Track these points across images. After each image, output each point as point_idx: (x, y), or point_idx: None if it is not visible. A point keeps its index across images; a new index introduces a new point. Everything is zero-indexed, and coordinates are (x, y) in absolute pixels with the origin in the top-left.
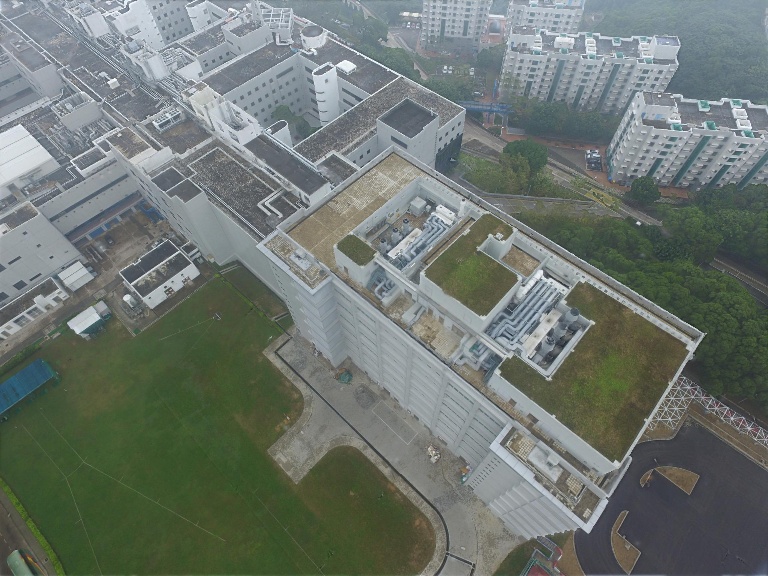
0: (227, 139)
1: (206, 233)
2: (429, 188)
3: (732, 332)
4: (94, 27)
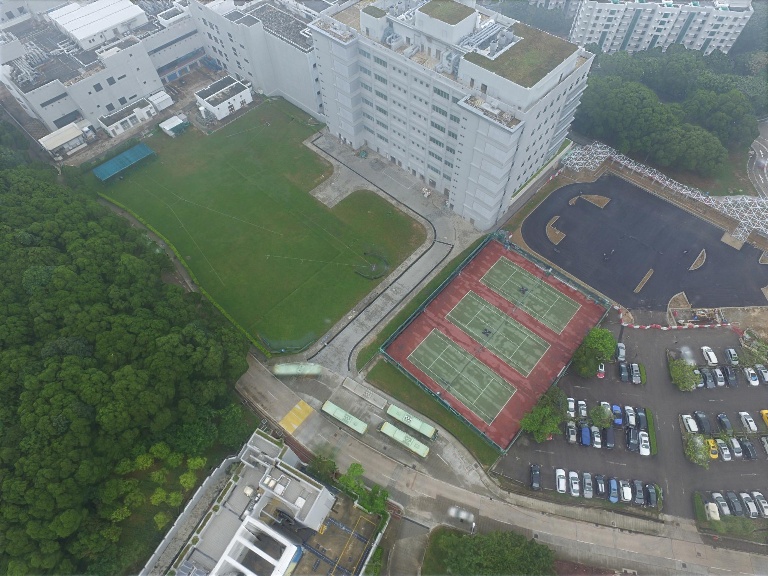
0: None
1: (260, 61)
2: None
3: (635, 104)
4: None
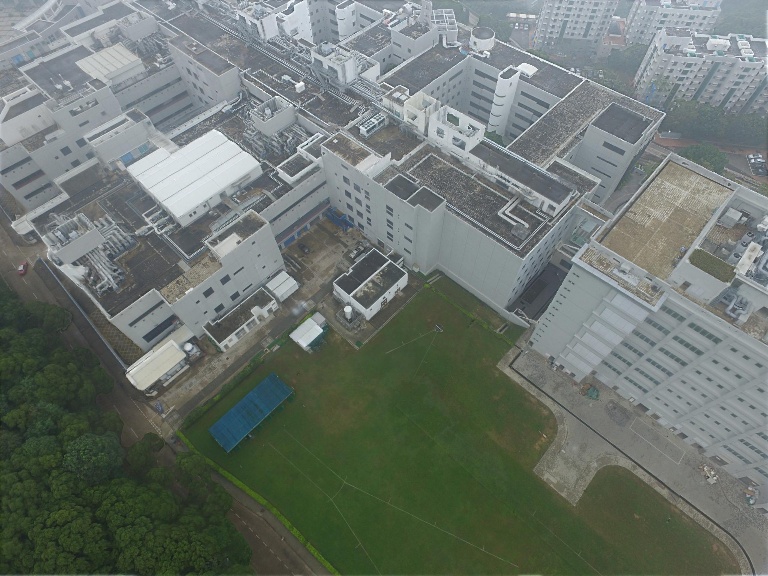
0: (444, 145)
1: (430, 242)
2: (750, 199)
3: None
4: (267, 29)
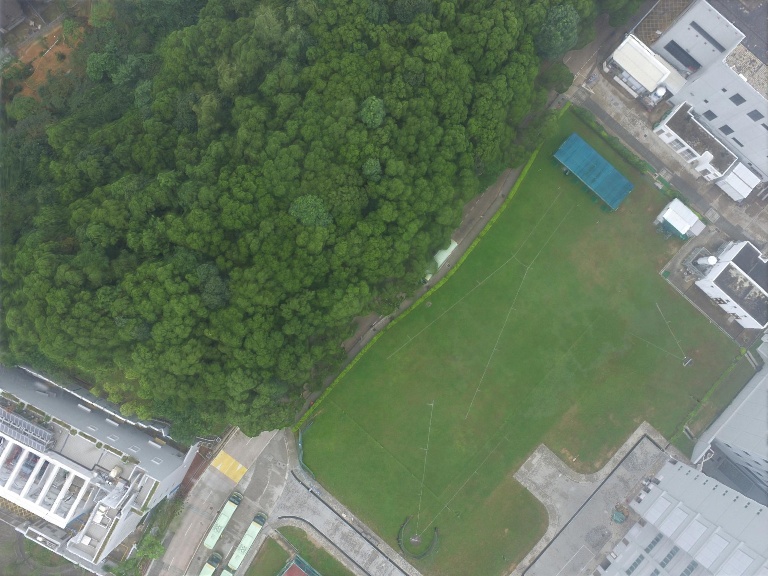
0: None
1: None
2: None
3: None
4: None
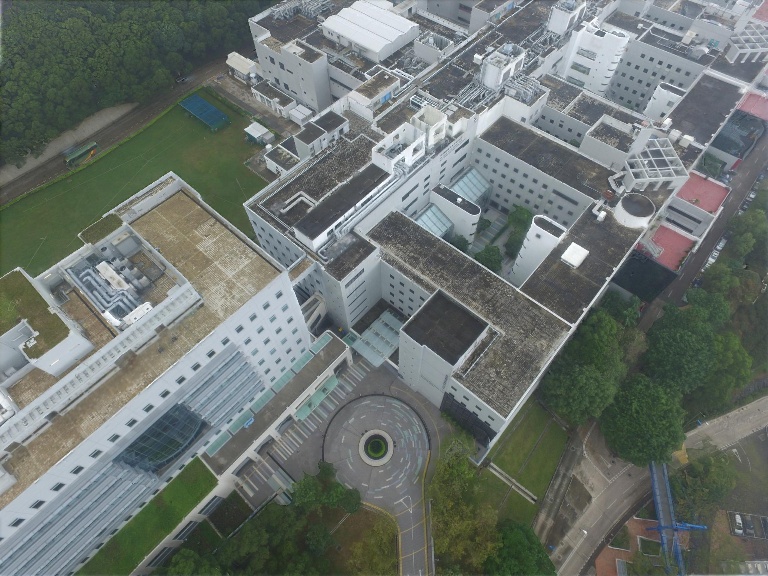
0: None
1: None
2: None
3: None
4: (555, 21)
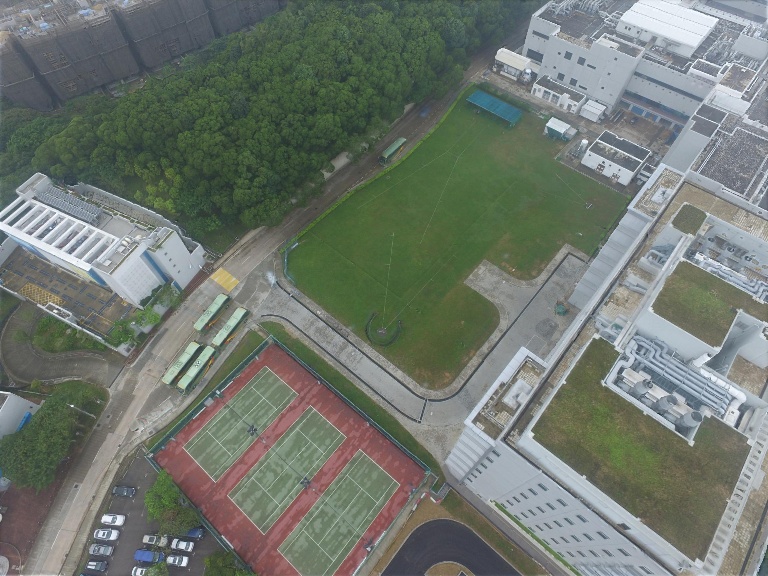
0: None
1: None
2: None
3: None
4: None
